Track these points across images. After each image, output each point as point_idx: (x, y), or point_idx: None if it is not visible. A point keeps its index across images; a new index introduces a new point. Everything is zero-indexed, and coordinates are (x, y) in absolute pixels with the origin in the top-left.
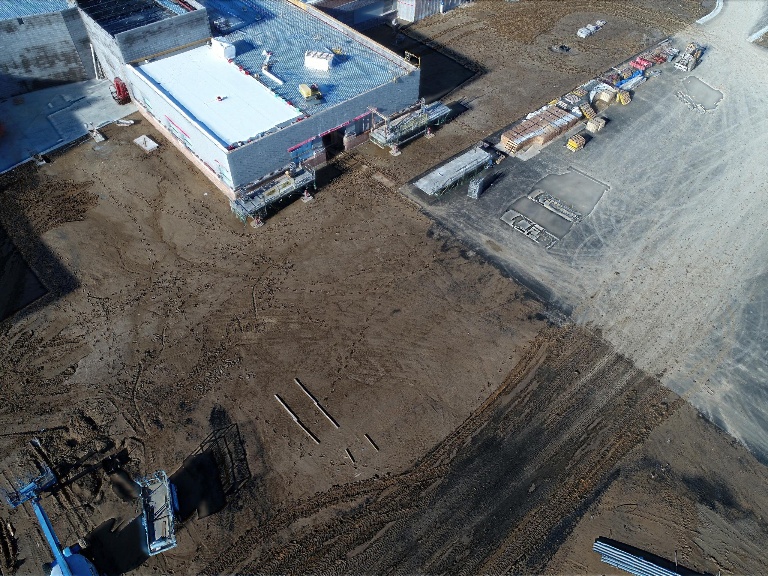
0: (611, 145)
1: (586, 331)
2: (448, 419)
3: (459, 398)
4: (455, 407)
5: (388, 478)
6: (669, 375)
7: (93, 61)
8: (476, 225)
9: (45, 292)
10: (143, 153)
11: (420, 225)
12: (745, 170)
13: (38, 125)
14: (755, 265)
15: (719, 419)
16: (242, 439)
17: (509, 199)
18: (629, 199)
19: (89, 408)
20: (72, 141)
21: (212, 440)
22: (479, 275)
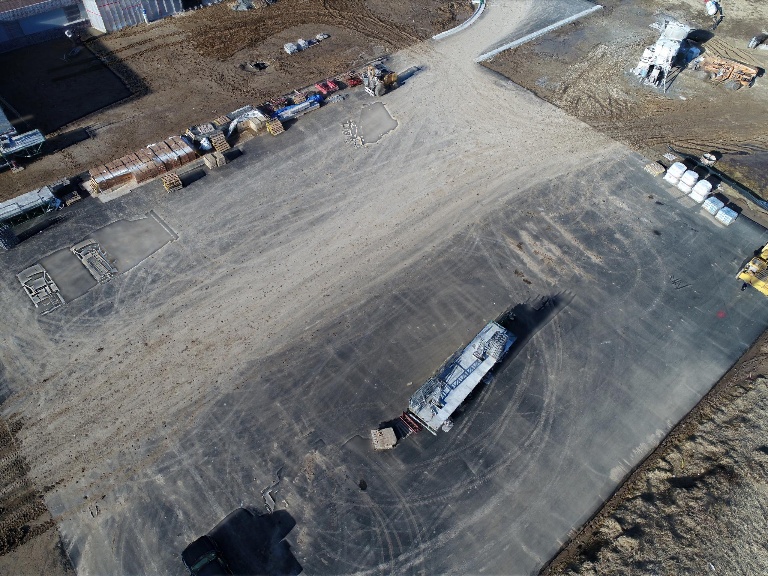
0: (220, 185)
1: (3, 425)
2: None
3: None
4: None
5: None
6: (60, 488)
7: None
8: None
9: None
10: None
11: None
12: (352, 219)
13: None
14: (275, 342)
15: (78, 551)
16: None
17: (46, 250)
18: (189, 253)
19: None
20: None
21: None
22: None
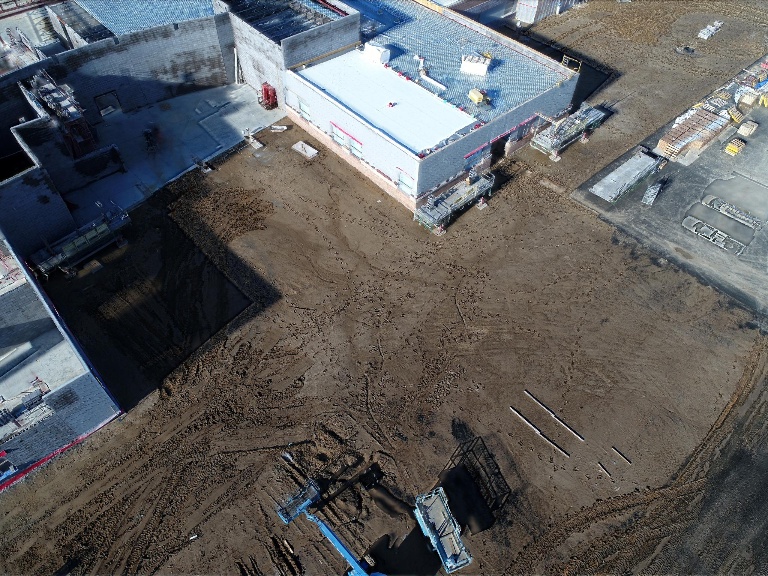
0: (767, 149)
1: None
2: (690, 431)
3: (695, 409)
4: (693, 419)
5: (649, 492)
6: None
7: (235, 66)
8: (659, 232)
9: (249, 303)
10: (304, 159)
11: (602, 232)
12: None
13: (192, 131)
14: None
15: None
16: (491, 453)
17: (684, 205)
18: None
19: (329, 421)
20: (231, 148)
21: (461, 454)
22: (677, 283)
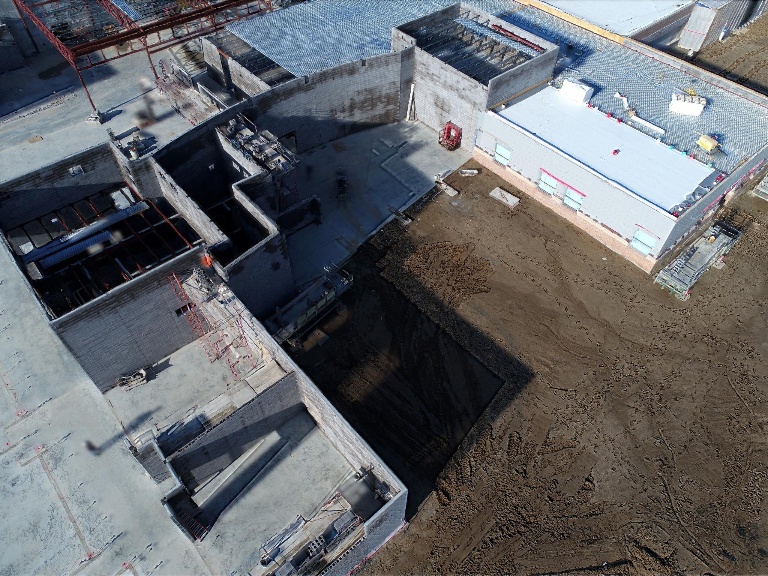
0: None
1: None
2: None
3: None
4: None
5: None
6: None
7: (409, 102)
8: None
9: (501, 382)
10: (507, 209)
11: None
12: None
13: (377, 176)
14: None
15: None
16: None
17: None
18: None
19: (639, 535)
20: (424, 195)
21: None
22: None
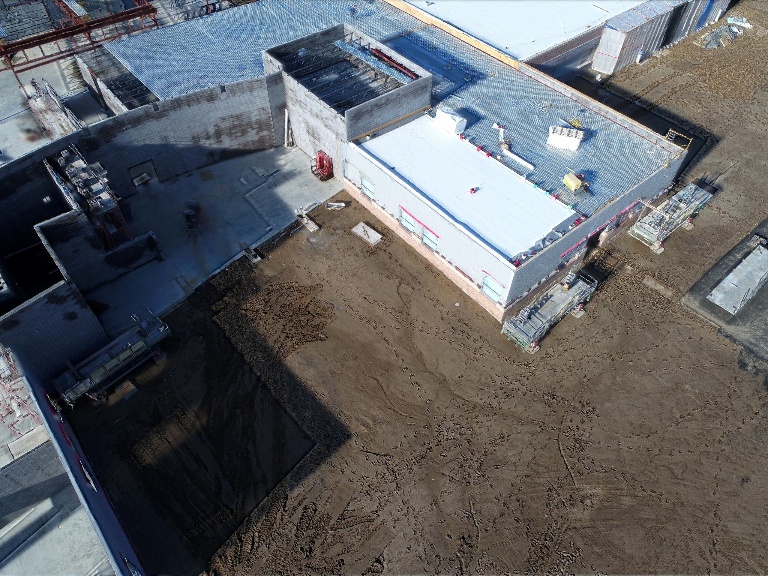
0: None
1: None
2: None
3: None
4: None
5: None
6: None
7: (285, 128)
8: None
9: (312, 444)
10: (367, 246)
11: (726, 352)
12: None
13: (237, 207)
14: None
15: None
16: None
17: None
18: None
19: None
20: (282, 229)
21: None
22: None
